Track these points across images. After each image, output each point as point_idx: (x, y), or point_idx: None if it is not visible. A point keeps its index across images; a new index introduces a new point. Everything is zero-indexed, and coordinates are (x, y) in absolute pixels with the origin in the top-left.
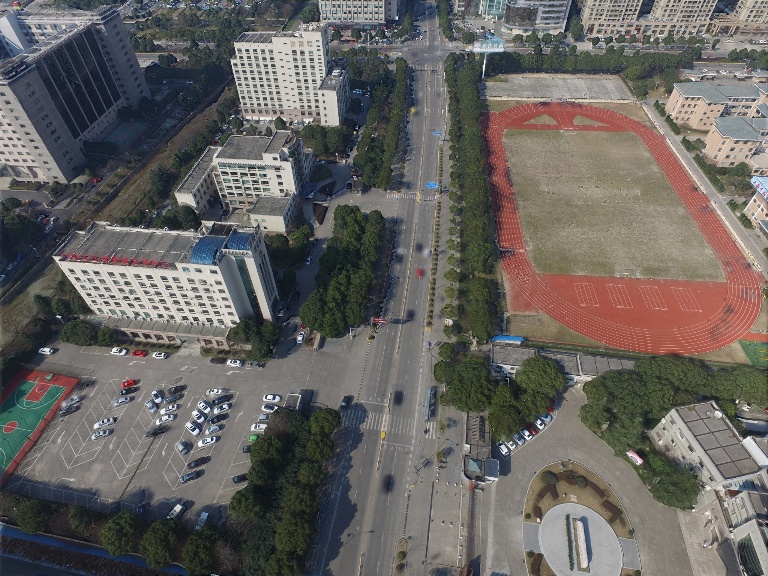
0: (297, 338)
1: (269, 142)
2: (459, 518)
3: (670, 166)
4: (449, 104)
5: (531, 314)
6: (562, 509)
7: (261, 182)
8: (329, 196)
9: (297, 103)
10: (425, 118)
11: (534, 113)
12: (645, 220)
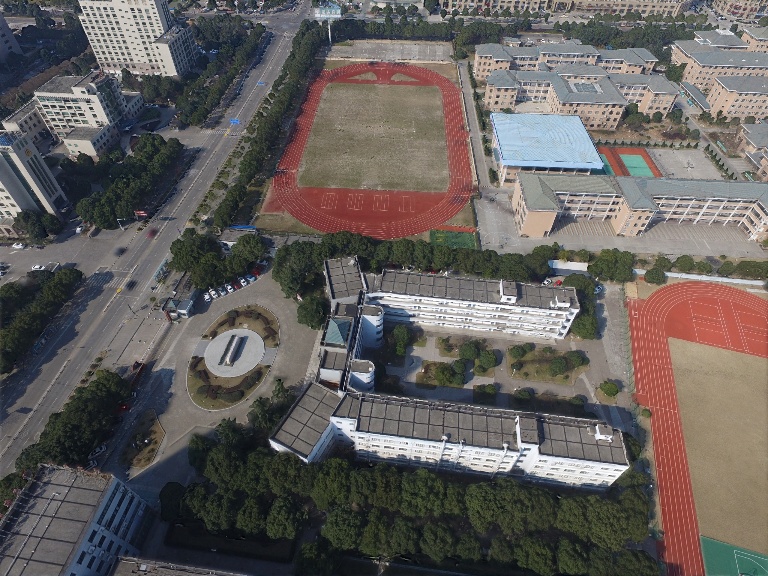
0: (76, 229)
1: (81, 79)
2: (153, 338)
3: (453, 112)
4: (285, 61)
5: (277, 214)
6: (233, 332)
7: (78, 114)
8: (150, 131)
9: (145, 58)
10: (264, 74)
11: (361, 71)
12: (408, 150)
